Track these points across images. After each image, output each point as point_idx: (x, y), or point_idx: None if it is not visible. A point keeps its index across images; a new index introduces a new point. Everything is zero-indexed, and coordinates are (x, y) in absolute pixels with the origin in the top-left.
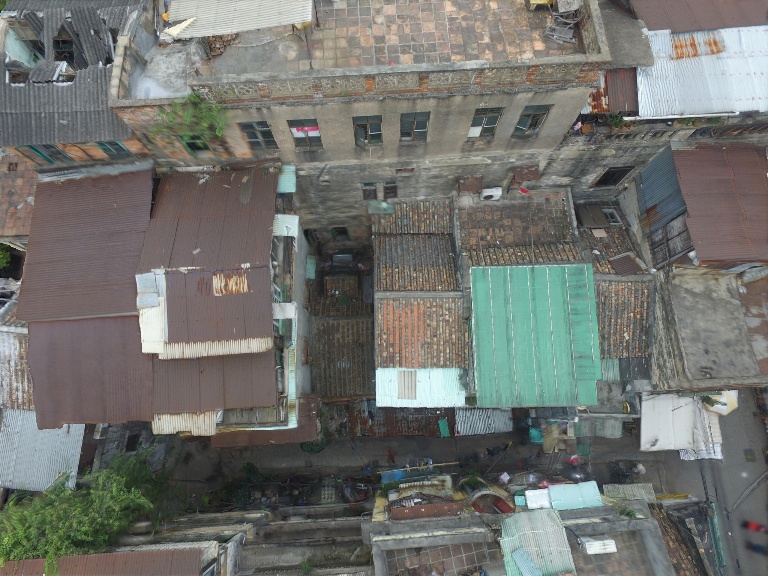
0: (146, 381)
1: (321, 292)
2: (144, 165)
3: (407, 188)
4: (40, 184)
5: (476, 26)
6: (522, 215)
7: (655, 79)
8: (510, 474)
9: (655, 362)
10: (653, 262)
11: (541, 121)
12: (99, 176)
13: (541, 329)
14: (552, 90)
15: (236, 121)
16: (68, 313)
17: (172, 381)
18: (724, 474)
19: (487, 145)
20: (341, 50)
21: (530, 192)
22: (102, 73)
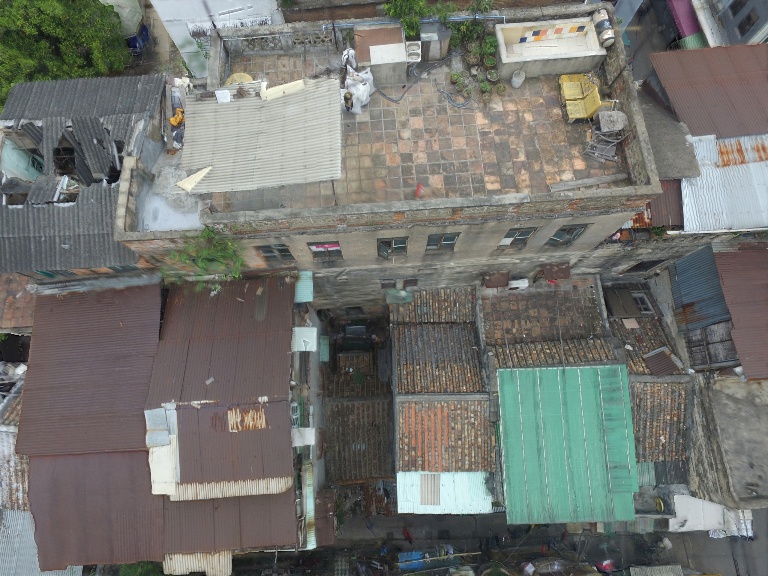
0: (156, 519)
1: (334, 369)
2: (151, 278)
3: (428, 281)
4: (40, 297)
5: (510, 141)
6: (549, 305)
7: (700, 190)
8: (535, 565)
9: (694, 468)
10: (690, 361)
11: (577, 232)
12: (103, 290)
13: (573, 437)
14: (594, 215)
15: (252, 245)
16: (72, 448)
17: (184, 518)
18: (753, 546)
19: (517, 251)
20: (365, 170)
21: (557, 279)
22: (106, 193)
